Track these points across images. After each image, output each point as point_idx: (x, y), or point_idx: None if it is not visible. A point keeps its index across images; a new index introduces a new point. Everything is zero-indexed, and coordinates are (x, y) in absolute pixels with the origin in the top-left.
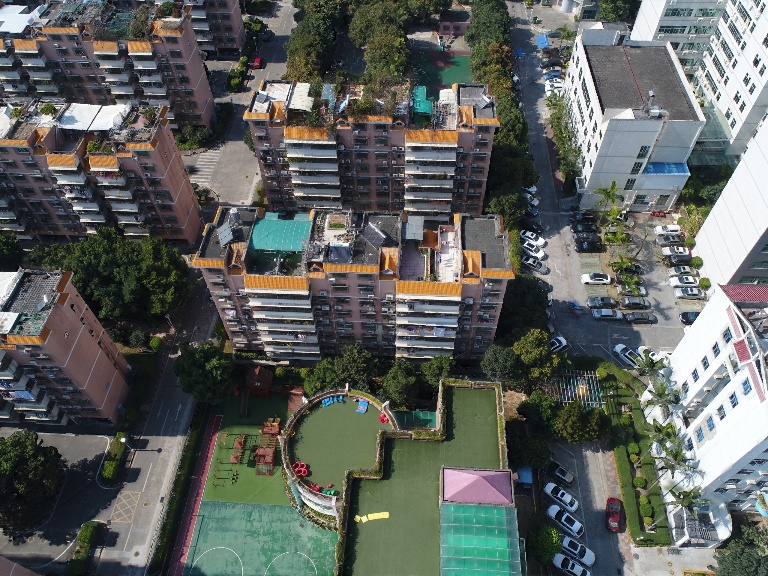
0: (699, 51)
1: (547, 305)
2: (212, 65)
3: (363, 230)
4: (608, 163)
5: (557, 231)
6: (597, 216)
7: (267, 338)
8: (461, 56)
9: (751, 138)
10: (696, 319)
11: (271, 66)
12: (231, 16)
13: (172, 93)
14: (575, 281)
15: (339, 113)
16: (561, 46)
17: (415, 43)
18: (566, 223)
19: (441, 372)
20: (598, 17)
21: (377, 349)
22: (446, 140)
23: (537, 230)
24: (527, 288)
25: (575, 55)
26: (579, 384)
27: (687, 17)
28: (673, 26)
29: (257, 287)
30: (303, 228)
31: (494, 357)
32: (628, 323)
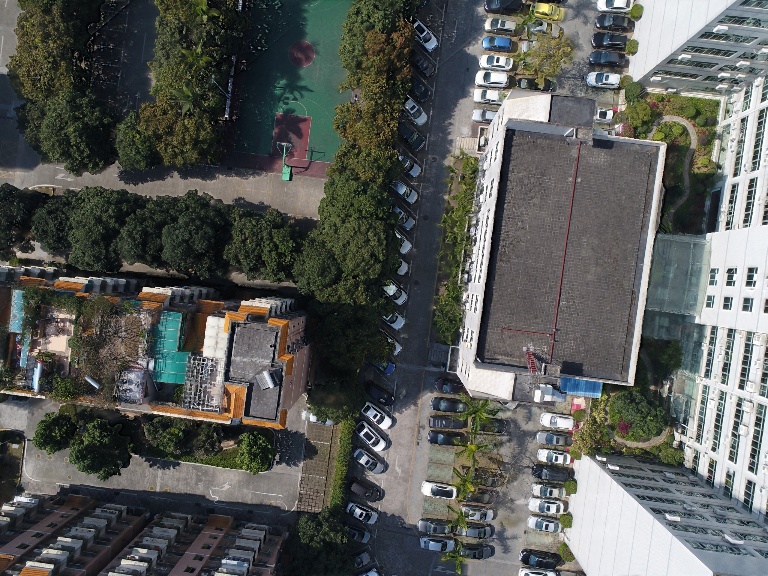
0: (750, 74)
1: None
2: None
3: None
4: None
5: (414, 401)
6: None
7: None
8: None
9: None
10: None
11: None
12: None
13: None
14: (414, 486)
15: (32, 387)
16: None
17: None
18: (430, 388)
19: None
20: None
21: None
22: (211, 417)
23: (385, 405)
24: (325, 566)
25: None
26: None
27: (742, 43)
28: (712, 47)
29: None
30: None
31: None
32: None
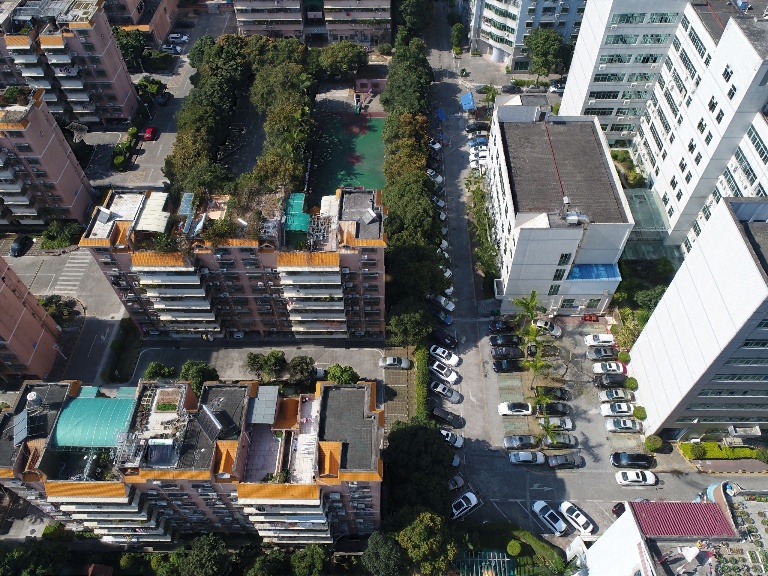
0: (636, 116)
1: (450, 460)
2: (97, 138)
3: (198, 414)
4: (526, 271)
5: (474, 344)
6: (520, 322)
7: (101, 530)
8: (379, 119)
9: (691, 229)
10: (608, 529)
11: (165, 137)
12: (113, 85)
13: (30, 188)
14: (492, 411)
15: (194, 237)
16: (490, 104)
17: (329, 104)
18: (485, 332)
19: (312, 570)
20: (530, 70)
21: (244, 528)
22: (325, 263)
23: (450, 345)
24: (424, 443)
25: (493, 132)
26: (483, 573)
27: (619, 82)
28: (604, 91)
29: (62, 495)
30: (123, 413)
31: (374, 553)
32: (551, 468)
